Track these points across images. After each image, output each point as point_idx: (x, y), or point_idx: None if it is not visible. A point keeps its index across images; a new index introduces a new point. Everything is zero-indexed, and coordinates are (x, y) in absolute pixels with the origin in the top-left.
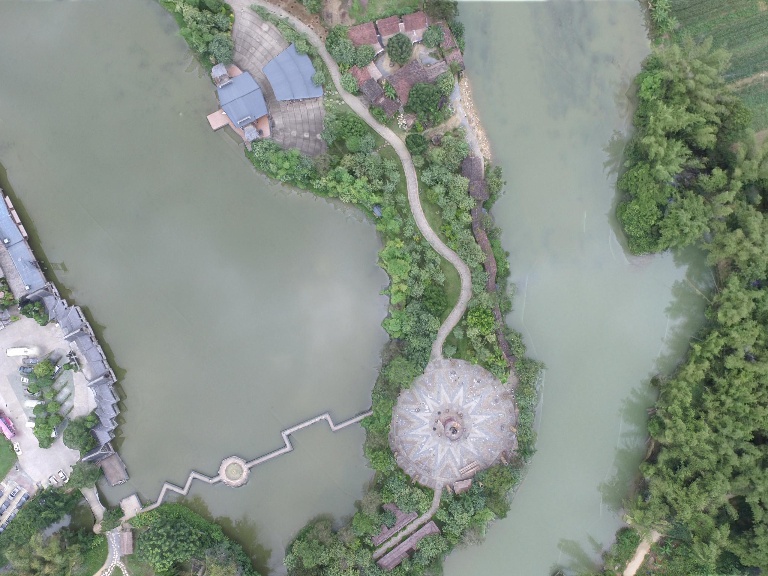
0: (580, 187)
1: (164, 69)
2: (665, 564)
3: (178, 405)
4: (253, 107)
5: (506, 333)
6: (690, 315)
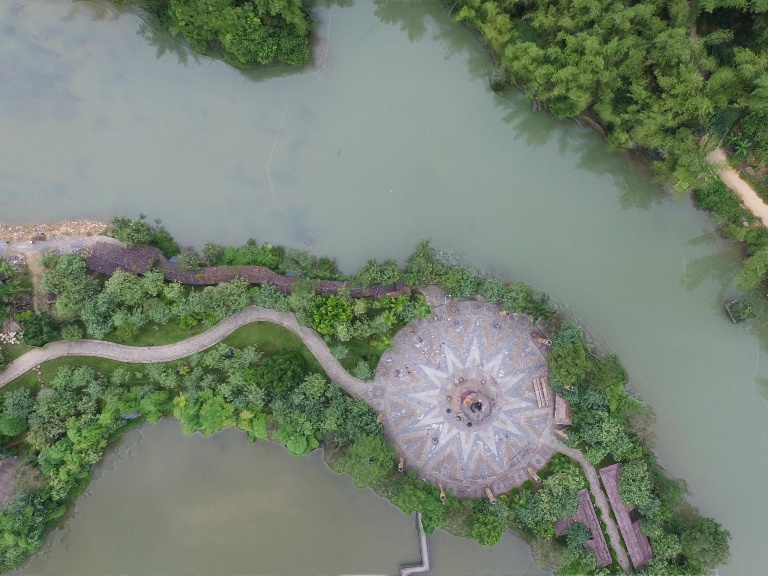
0: (189, 108)
1: None
2: (762, 155)
3: None
4: None
5: (360, 283)
6: (421, 8)
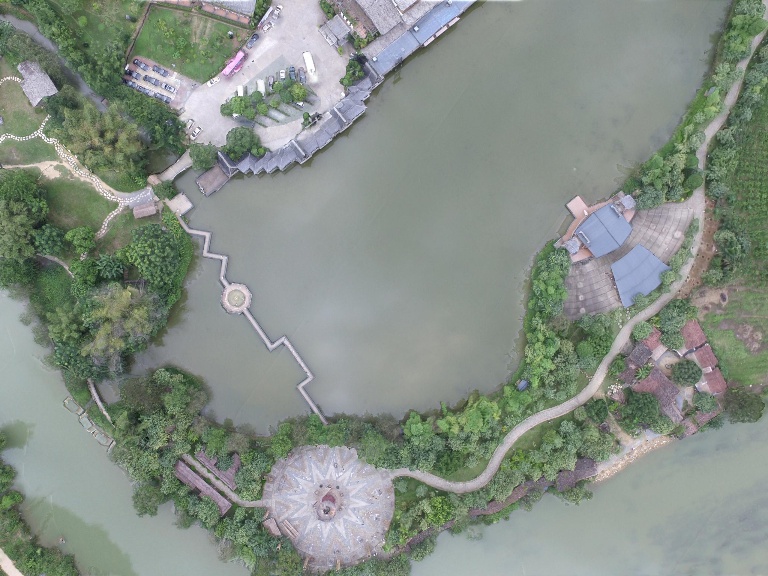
0: (587, 573)
1: (616, 143)
2: None
3: (290, 228)
4: (600, 243)
5: (432, 538)
6: None
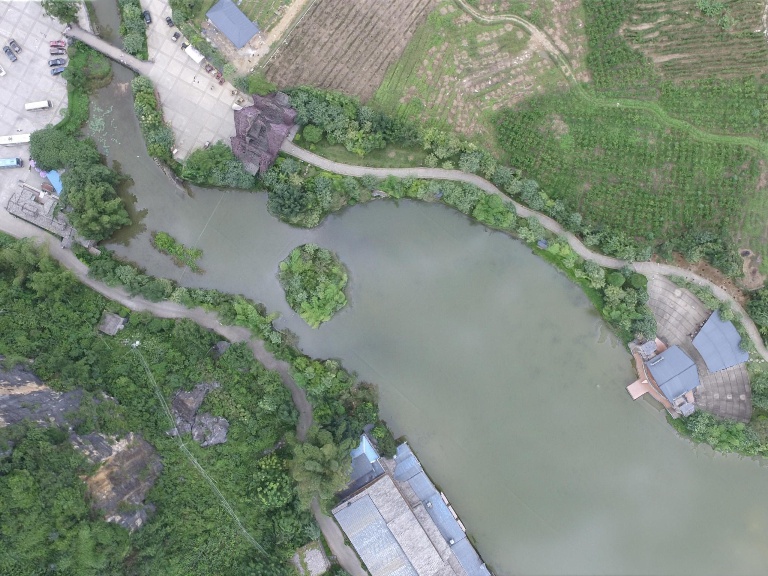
0: None
1: (577, 342)
2: None
3: None
4: (687, 382)
5: None
6: None
